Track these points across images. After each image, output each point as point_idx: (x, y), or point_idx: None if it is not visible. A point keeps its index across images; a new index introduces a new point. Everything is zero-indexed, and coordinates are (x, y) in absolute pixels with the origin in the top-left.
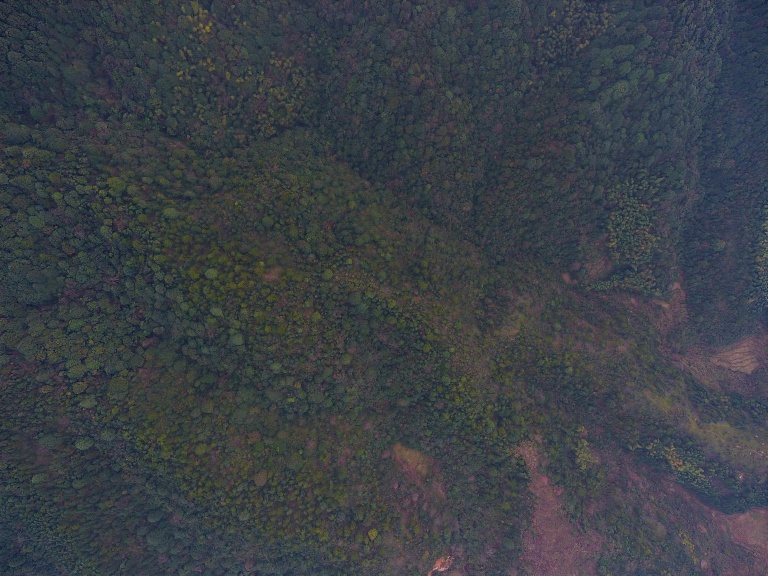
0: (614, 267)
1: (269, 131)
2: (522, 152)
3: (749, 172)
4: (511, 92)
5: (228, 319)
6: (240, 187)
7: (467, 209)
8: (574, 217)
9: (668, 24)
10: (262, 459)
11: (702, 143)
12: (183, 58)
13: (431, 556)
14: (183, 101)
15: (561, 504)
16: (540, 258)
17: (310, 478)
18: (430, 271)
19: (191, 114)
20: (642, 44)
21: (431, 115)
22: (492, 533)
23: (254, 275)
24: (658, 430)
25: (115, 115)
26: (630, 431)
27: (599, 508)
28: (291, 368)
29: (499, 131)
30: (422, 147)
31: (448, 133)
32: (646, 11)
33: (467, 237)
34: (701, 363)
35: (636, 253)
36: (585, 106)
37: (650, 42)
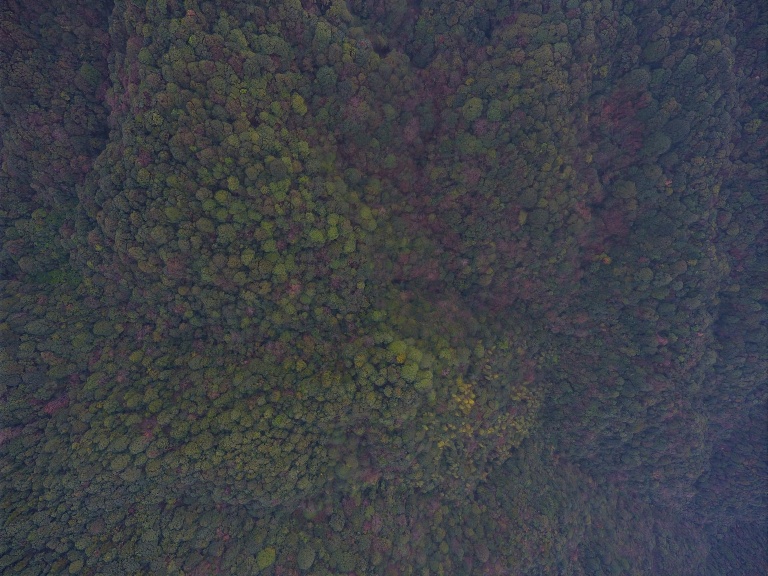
0: None
1: (505, 457)
2: (760, 454)
3: None
4: (751, 400)
5: None
6: (510, 559)
7: None
8: None
9: None
10: None
11: None
12: (445, 430)
13: None
14: (439, 463)
15: None
16: (757, 528)
17: None
18: None
19: (444, 471)
20: None
21: (675, 436)
22: None
23: None
24: None
25: (374, 488)
26: None
27: None
28: None
29: (730, 427)
30: (658, 457)
31: None
32: None
33: (686, 517)
34: None
35: None
36: None
37: None
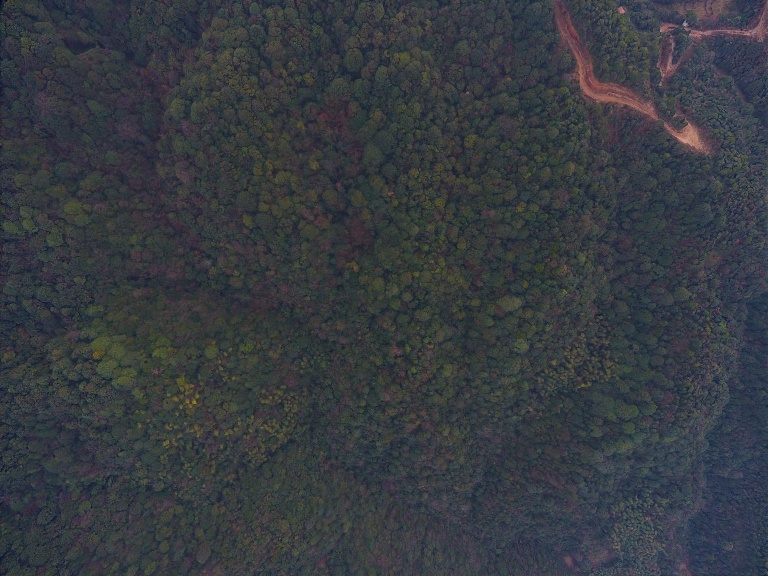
0: None
1: (260, 460)
2: (522, 470)
3: (758, 481)
4: (510, 416)
5: None
6: (229, 561)
7: (465, 510)
8: (576, 524)
9: (674, 398)
10: None
11: (709, 455)
12: (169, 429)
13: None
14: (170, 462)
15: None
16: (541, 545)
17: None
18: None
19: (178, 470)
20: (647, 412)
21: (427, 448)
22: None
23: None
24: None
25: (99, 483)
26: None
27: None
28: None
29: (498, 442)
30: (418, 468)
31: (445, 459)
32: (651, 376)
33: (466, 530)
34: None
35: (640, 552)
36: (587, 454)
37: (655, 411)
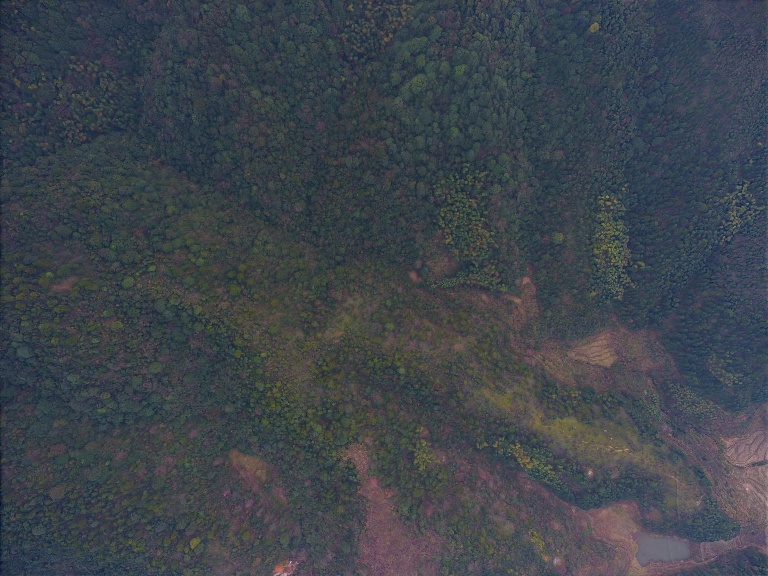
0: (460, 263)
1: (78, 137)
2: (343, 150)
3: (580, 163)
4: (325, 89)
5: (9, 332)
6: (27, 197)
7: (299, 210)
8: (405, 214)
9: (455, 14)
10: (64, 472)
11: (529, 135)
12: None
13: (264, 562)
14: None
15: (393, 506)
16: (383, 257)
17: (117, 489)
18: (247, 275)
19: None
20: (433, 36)
21: (240, 116)
22: (331, 537)
23: (39, 286)
24: (499, 428)
25: None
26: (474, 430)
27: (443, 508)
28: (94, 379)
29: (322, 129)
30: (239, 148)
31: (262, 133)
32: (437, 2)
33: (305, 238)
34: (557, 358)
35: (474, 249)
36: (388, 101)
37: (440, 34)
